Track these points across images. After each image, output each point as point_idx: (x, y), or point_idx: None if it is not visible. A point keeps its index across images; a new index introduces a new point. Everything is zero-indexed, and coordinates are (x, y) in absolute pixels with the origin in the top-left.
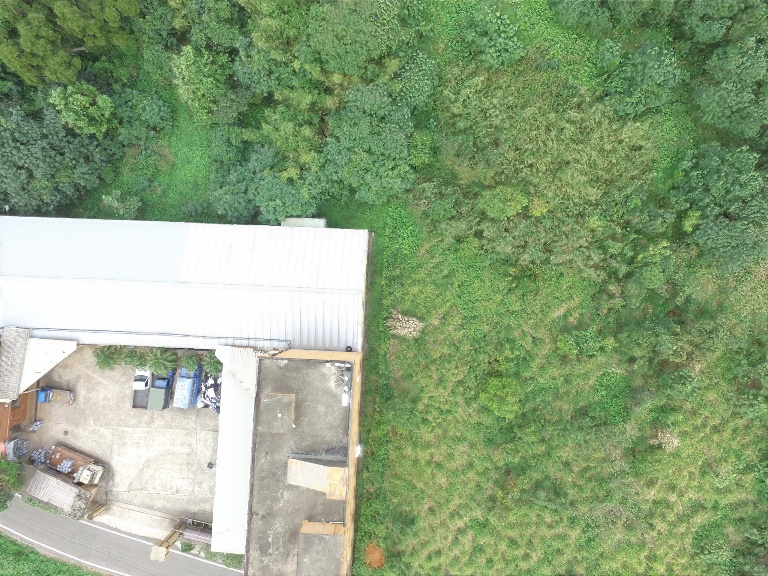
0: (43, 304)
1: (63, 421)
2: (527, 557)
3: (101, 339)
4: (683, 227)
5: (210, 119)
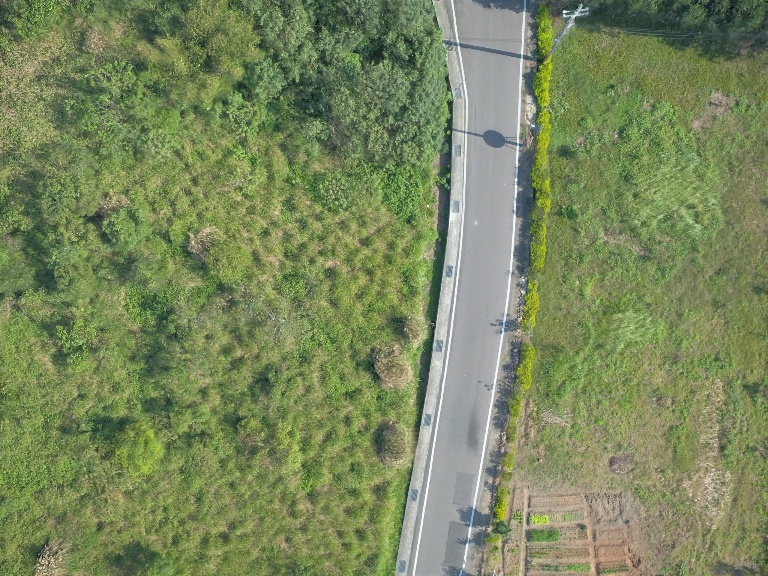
0: None
1: None
2: (348, 419)
3: None
4: None
5: None
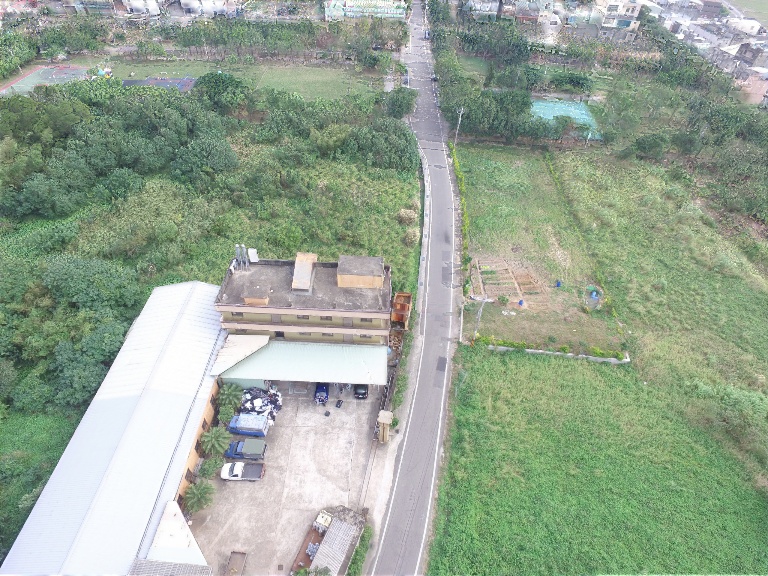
0: (111, 536)
1: (266, 572)
2: None
3: (174, 480)
4: (213, 178)
5: (1, 407)
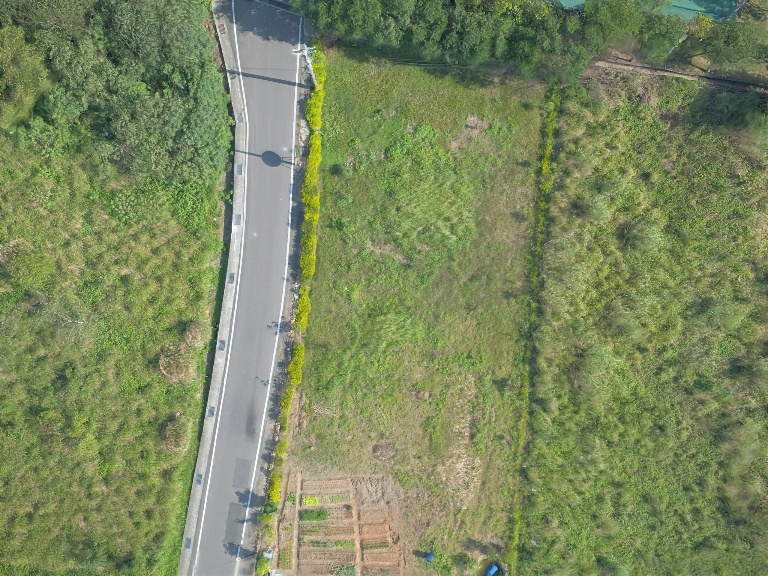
0: None
1: None
2: (140, 411)
3: None
4: None
5: None
